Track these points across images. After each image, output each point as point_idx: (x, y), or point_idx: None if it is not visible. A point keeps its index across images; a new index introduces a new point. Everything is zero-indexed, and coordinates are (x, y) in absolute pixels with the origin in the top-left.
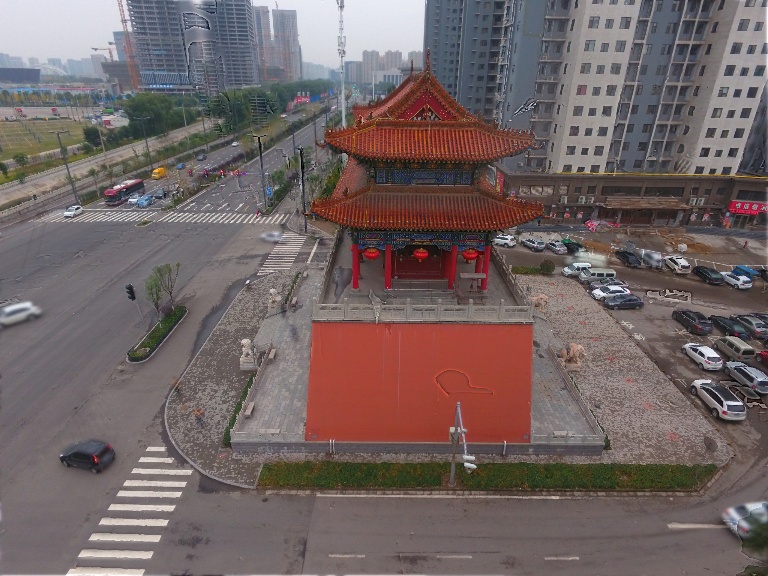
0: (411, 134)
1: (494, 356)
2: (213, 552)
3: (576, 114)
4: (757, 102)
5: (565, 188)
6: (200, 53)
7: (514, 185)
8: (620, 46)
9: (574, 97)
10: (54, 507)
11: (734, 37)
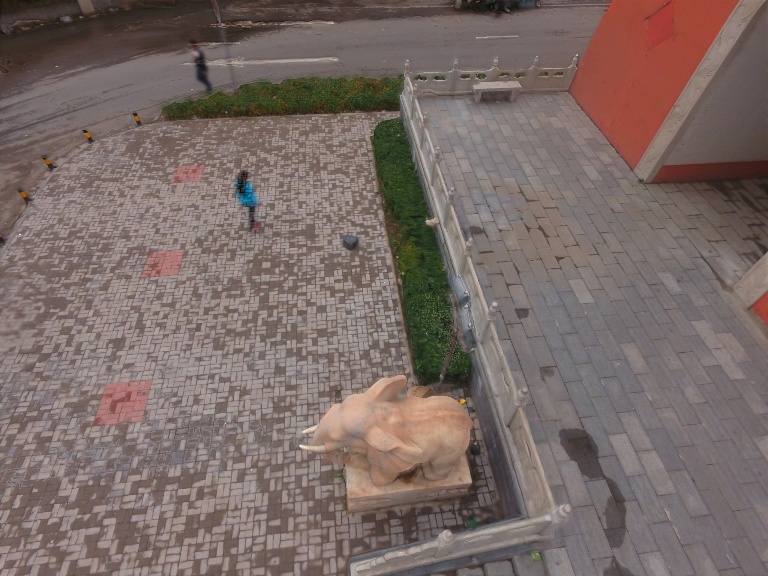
0: None
1: None
2: None
3: None
4: None
5: None
6: None
7: None
8: None
9: None
10: None
11: None
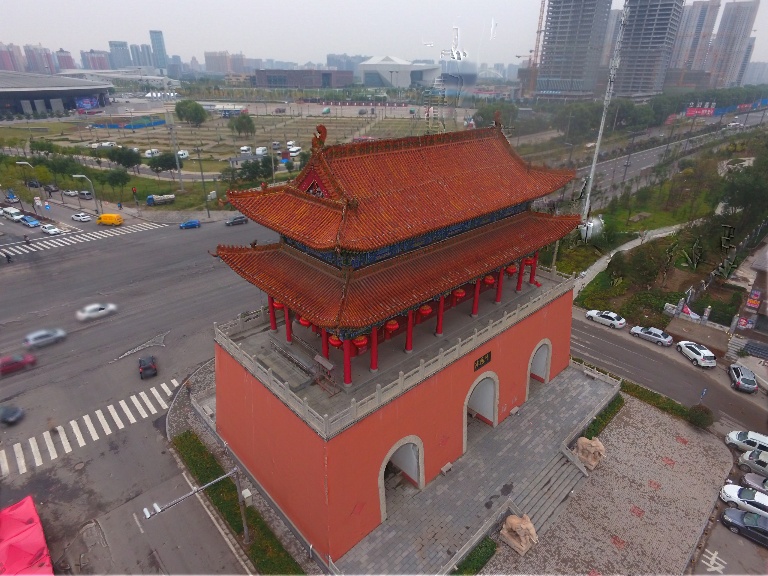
0: (299, 206)
1: (303, 451)
2: (110, 460)
3: None
4: None
5: None
6: (432, 84)
7: (761, 283)
8: None
9: None
10: (110, 385)
11: None
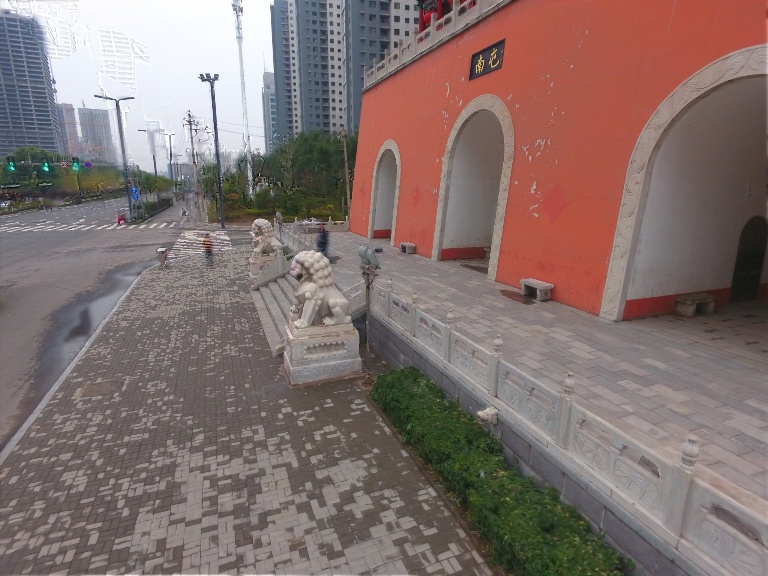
0: None
1: None
2: None
3: None
4: None
5: None
6: None
7: None
8: None
9: None
10: None
11: None
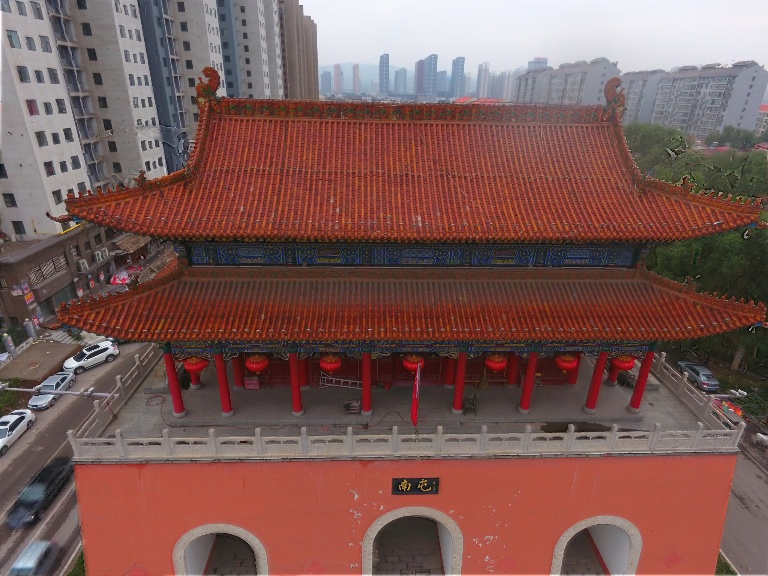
0: None
1: None
2: None
3: (41, 144)
4: (155, 111)
5: (73, 250)
6: None
7: (21, 275)
8: (45, 44)
9: (29, 119)
10: None
11: (122, 44)
